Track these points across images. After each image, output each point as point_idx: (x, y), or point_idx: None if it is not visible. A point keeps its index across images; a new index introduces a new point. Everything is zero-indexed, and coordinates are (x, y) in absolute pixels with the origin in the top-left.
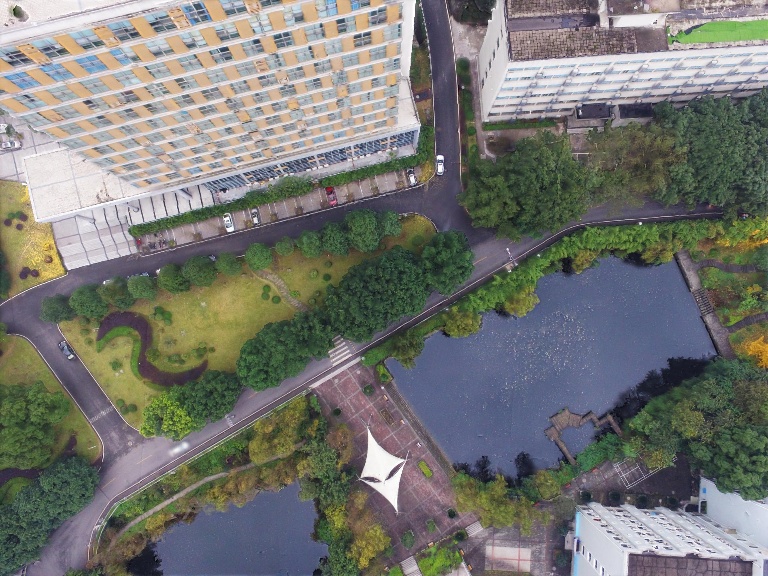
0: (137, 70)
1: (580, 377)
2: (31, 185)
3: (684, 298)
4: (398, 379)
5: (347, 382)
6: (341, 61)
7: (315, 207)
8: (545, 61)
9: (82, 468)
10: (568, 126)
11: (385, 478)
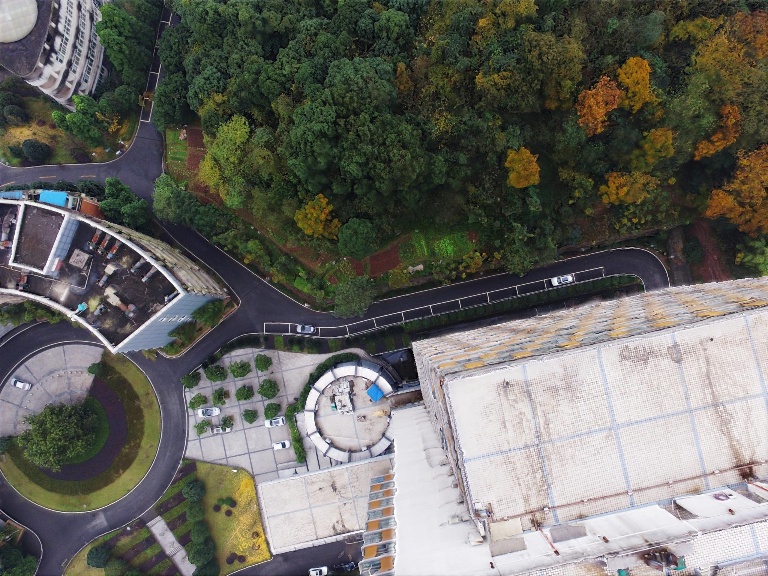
0: None
1: None
2: (268, 514)
3: None
4: None
5: None
6: None
7: None
8: None
9: None
10: None
11: None
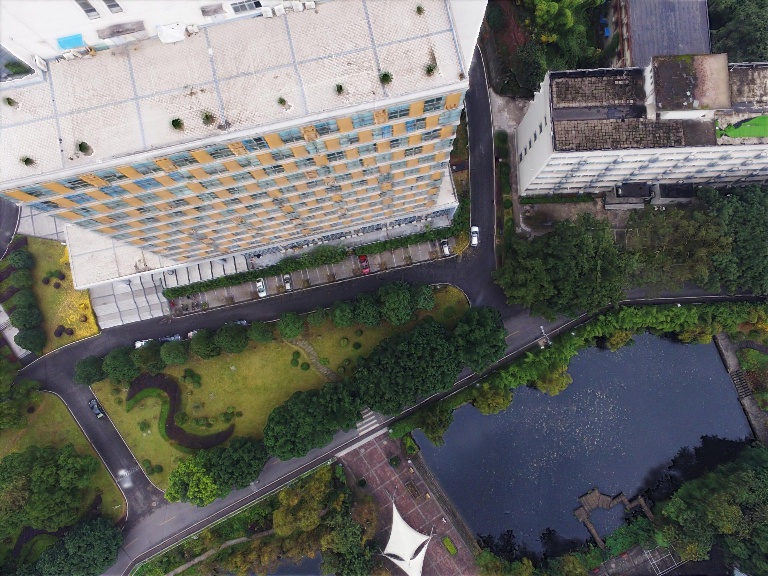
0: (191, 185)
1: (611, 457)
2: (72, 253)
3: (721, 379)
4: (425, 451)
5: (373, 452)
6: (389, 167)
7: (347, 274)
8: (590, 152)
9: (107, 530)
10: (606, 202)
11: (410, 558)
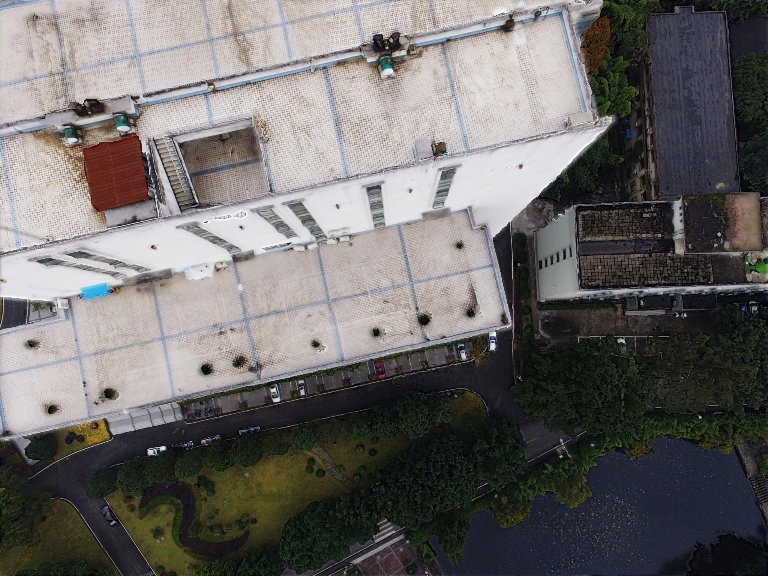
0: None
1: (629, 563)
2: None
3: (740, 484)
4: (441, 557)
5: (389, 559)
6: None
7: (363, 379)
8: None
9: None
10: (627, 308)
11: None
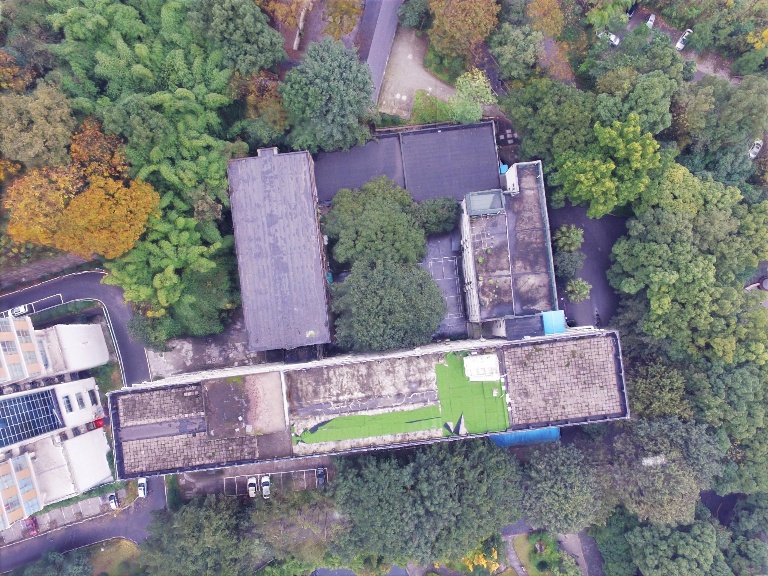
0: None
1: None
2: None
3: None
4: None
5: None
6: None
7: (17, 536)
8: None
9: None
10: None
11: None
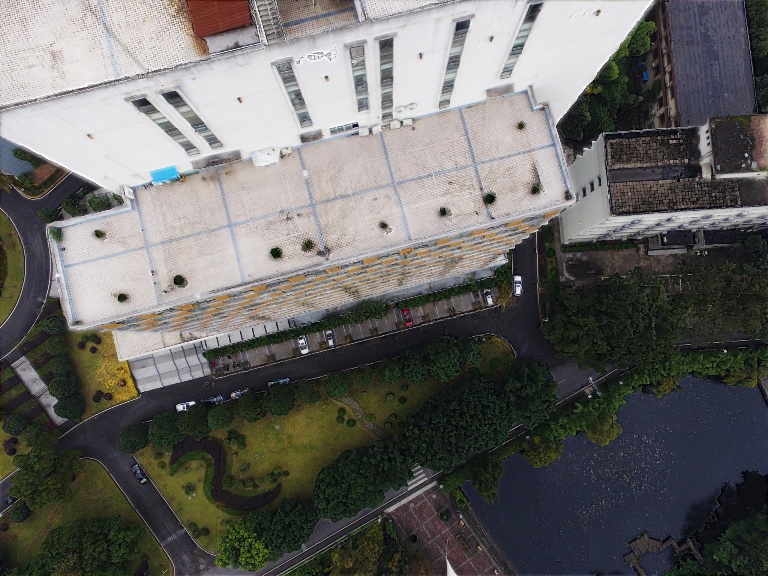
0: None
1: (659, 501)
2: None
3: (764, 419)
4: (474, 502)
5: (422, 506)
6: None
7: (390, 328)
8: (647, 215)
9: None
10: (649, 248)
11: None
